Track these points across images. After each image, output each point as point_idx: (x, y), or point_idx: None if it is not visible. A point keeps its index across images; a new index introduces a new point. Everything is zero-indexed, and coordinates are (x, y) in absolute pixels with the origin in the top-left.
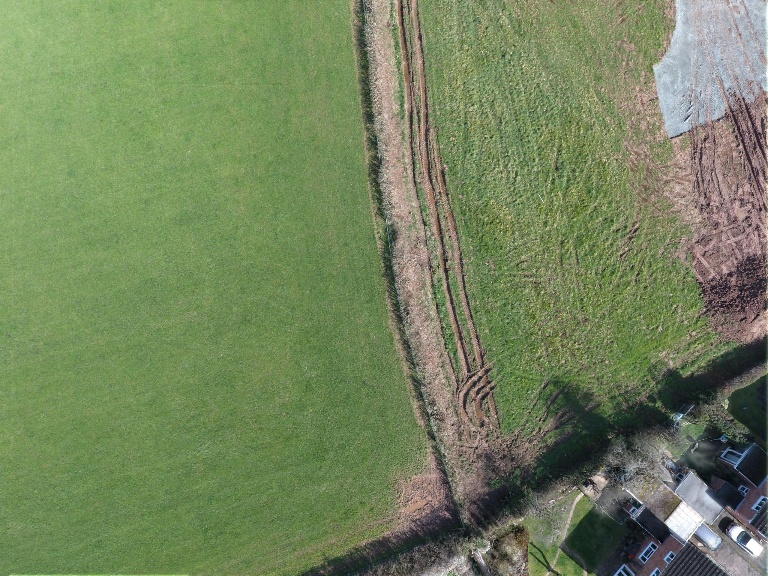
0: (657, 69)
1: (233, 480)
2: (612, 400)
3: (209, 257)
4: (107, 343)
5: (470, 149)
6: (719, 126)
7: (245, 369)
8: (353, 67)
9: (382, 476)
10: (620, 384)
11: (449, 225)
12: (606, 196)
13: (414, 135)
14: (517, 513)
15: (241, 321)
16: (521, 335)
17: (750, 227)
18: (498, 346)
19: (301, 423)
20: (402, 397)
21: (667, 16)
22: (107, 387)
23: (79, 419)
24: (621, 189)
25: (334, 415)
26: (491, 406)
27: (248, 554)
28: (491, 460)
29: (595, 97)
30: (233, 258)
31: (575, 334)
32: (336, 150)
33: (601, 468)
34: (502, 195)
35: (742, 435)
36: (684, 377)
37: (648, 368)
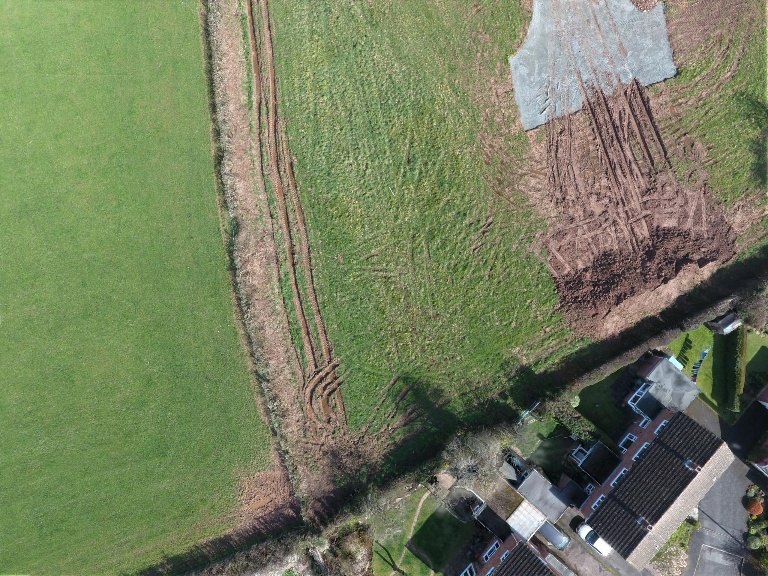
0: (513, 60)
1: (70, 476)
2: (463, 397)
3: (49, 250)
4: None
5: (319, 141)
6: (576, 119)
7: (85, 364)
8: (200, 57)
9: (224, 473)
10: (471, 380)
11: (298, 218)
12: (459, 189)
13: (262, 126)
14: (356, 511)
15: (82, 315)
16: (370, 330)
17: (607, 222)
18: (346, 341)
19: (142, 419)
20: (246, 393)
21: (523, 7)
22: None
23: None
24: (474, 182)
25: (176, 411)
26: (339, 402)
27: (84, 551)
28: (337, 457)
29: (449, 89)
30: (74, 251)
31: (426, 329)
32: (182, 141)
33: (445, 466)
34: (352, 188)
35: (588, 433)
36: (537, 374)
37: (500, 364)
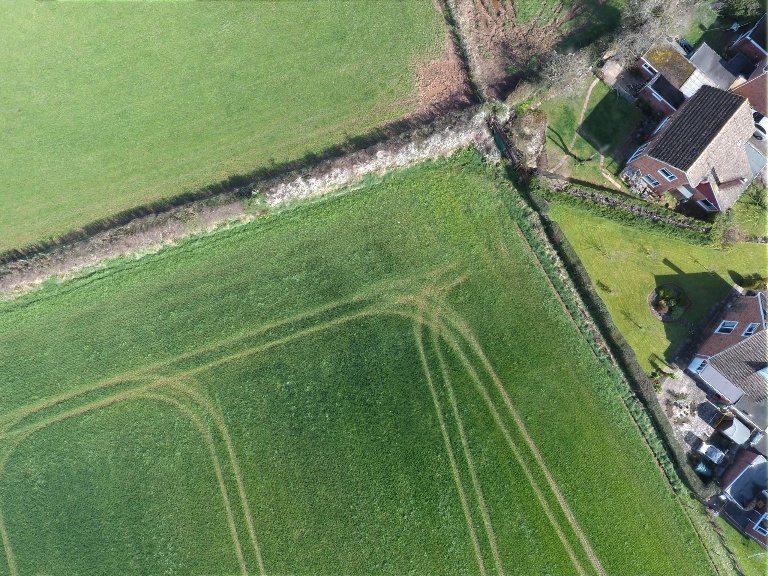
0: None
1: (254, 58)
2: None
3: None
4: None
5: None
6: None
7: None
8: None
9: (401, 59)
10: None
11: None
12: None
13: None
14: (535, 82)
15: None
16: None
17: None
18: None
19: (320, 7)
20: None
21: None
22: None
23: None
24: None
25: None
26: None
27: (270, 130)
28: (508, 47)
29: None
30: None
31: None
32: None
33: (616, 45)
34: None
35: None
36: None
37: None
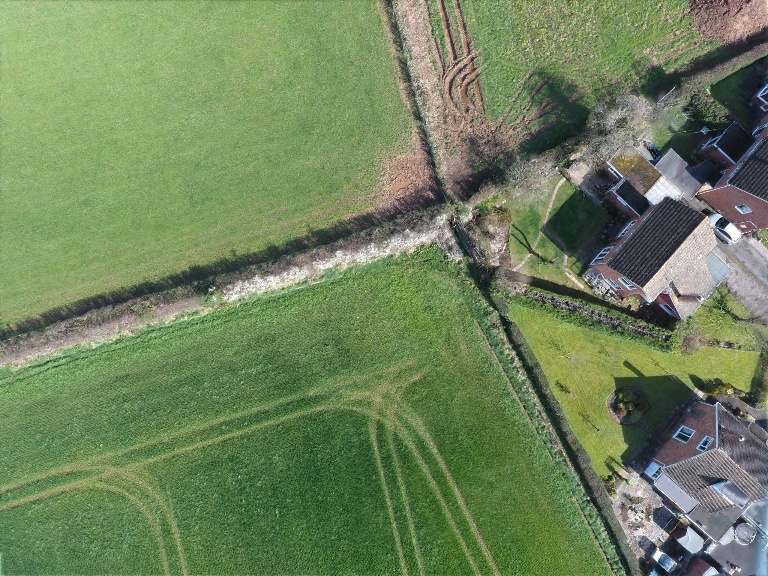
0: None
1: (220, 149)
2: (596, 92)
3: None
4: (98, 12)
5: None
6: None
7: (234, 44)
8: None
9: (367, 153)
10: (604, 78)
11: None
12: None
13: None
14: (499, 183)
15: None
16: (507, 25)
17: None
18: (484, 35)
19: (288, 99)
20: (389, 78)
21: None
22: (97, 53)
23: (69, 81)
24: None
25: (321, 92)
26: (476, 93)
27: (233, 221)
28: (475, 144)
29: None
30: None
31: (561, 27)
32: None
33: (583, 147)
34: None
35: (722, 116)
36: (667, 73)
37: (632, 64)
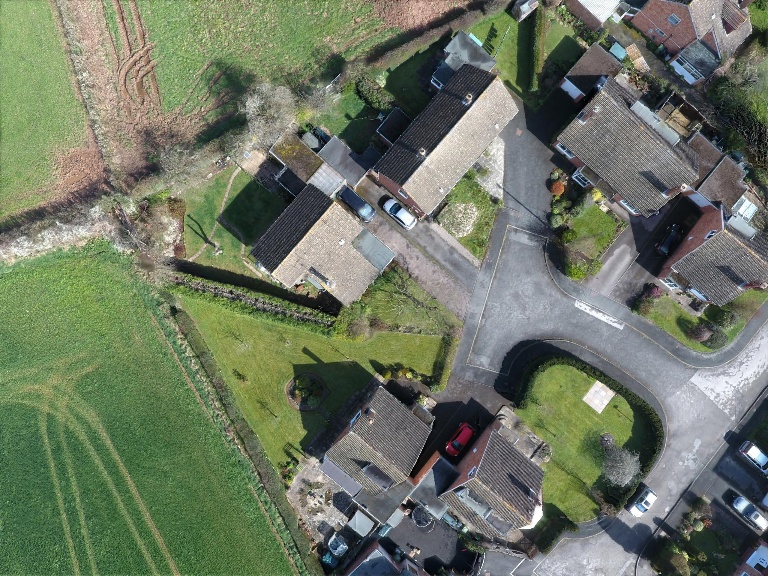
0: None
1: None
2: (274, 81)
3: None
4: None
5: None
6: None
7: None
8: None
9: (39, 147)
10: (283, 67)
11: None
12: None
13: None
14: (162, 174)
15: None
16: (183, 17)
17: None
18: (160, 27)
19: None
20: (60, 72)
21: None
22: None
23: None
24: None
25: None
26: (153, 85)
27: None
28: (150, 136)
29: None
30: None
31: (238, 17)
32: None
33: (251, 136)
34: None
35: None
36: (347, 61)
37: (312, 52)
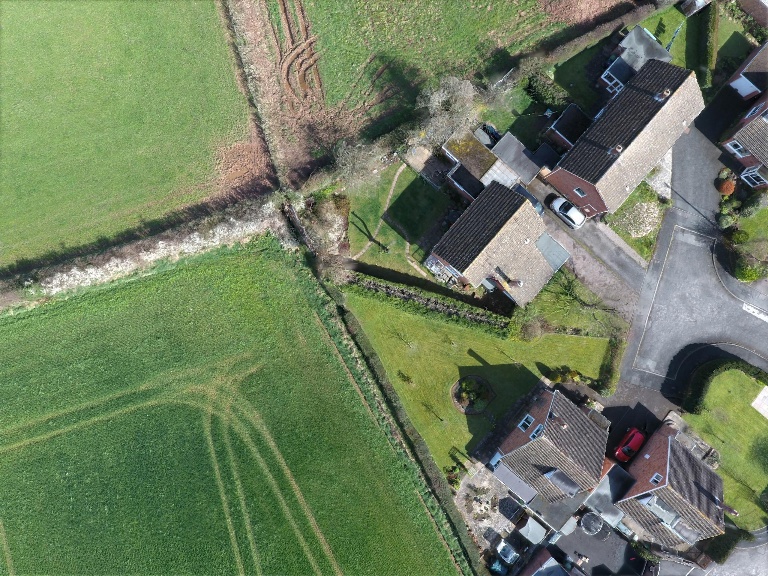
0: None
1: (48, 139)
2: (438, 76)
3: None
4: None
5: None
6: None
7: (63, 32)
8: None
9: (201, 141)
10: (447, 61)
11: None
12: None
13: None
14: (332, 170)
15: None
16: (347, 9)
17: None
18: (323, 19)
19: (119, 87)
20: (223, 64)
21: None
22: None
23: None
24: None
25: (153, 80)
26: (315, 79)
27: (62, 212)
28: (313, 130)
29: None
30: None
31: (402, 10)
32: None
33: (420, 131)
34: None
35: (561, 98)
36: (512, 56)
37: (476, 46)
